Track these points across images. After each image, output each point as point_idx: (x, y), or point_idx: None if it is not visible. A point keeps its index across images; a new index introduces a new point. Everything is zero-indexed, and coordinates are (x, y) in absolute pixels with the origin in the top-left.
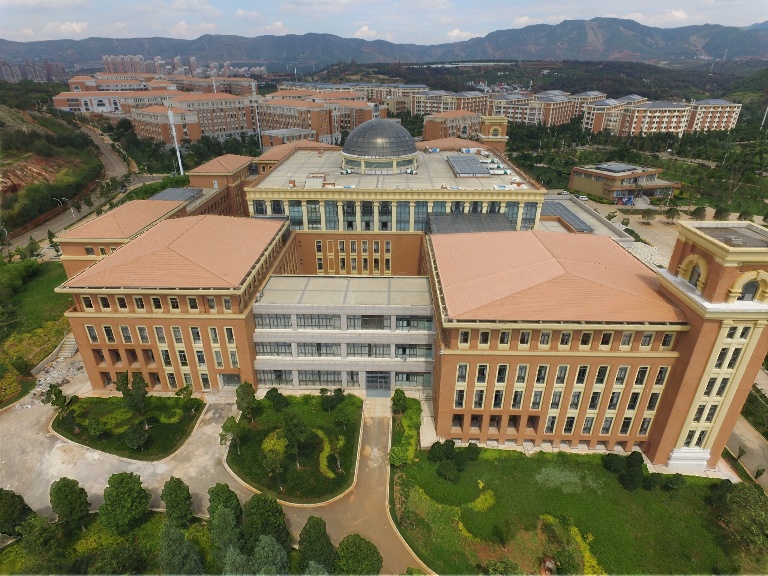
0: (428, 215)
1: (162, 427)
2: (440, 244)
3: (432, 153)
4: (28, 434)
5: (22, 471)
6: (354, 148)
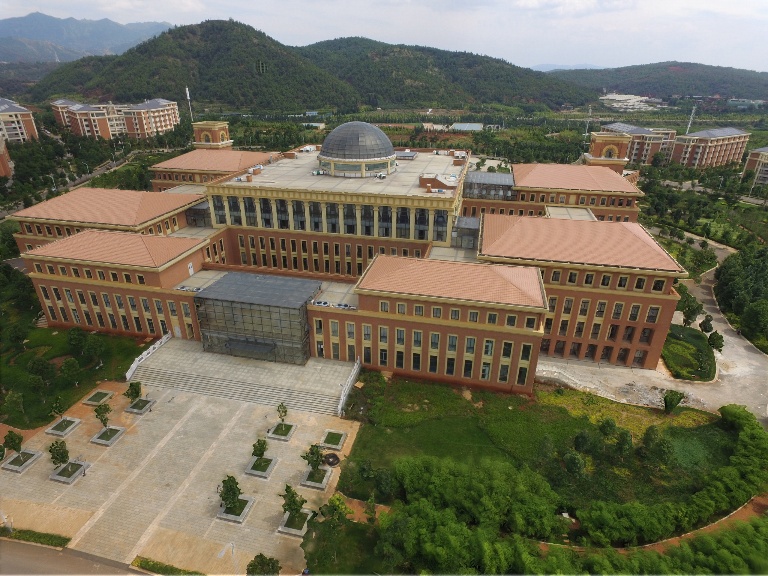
0: (469, 183)
1: (676, 331)
2: (537, 185)
3: (298, 157)
4: (728, 390)
5: (759, 383)
6: (378, 151)
